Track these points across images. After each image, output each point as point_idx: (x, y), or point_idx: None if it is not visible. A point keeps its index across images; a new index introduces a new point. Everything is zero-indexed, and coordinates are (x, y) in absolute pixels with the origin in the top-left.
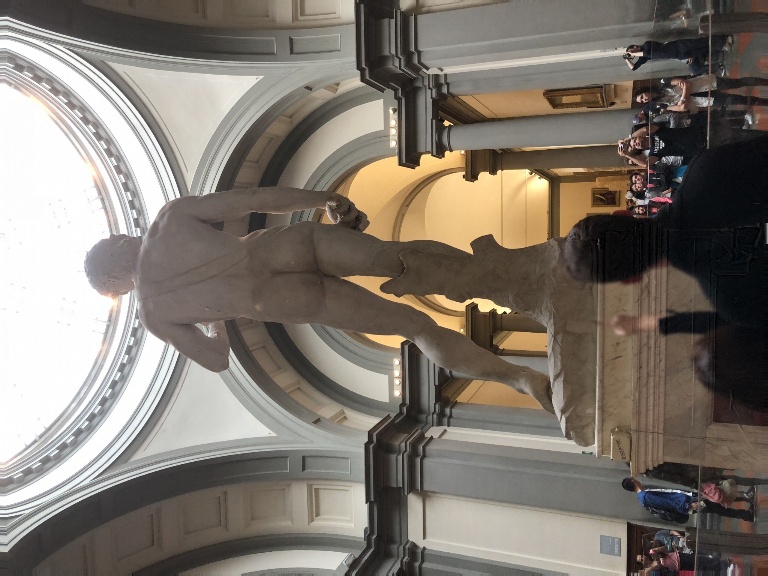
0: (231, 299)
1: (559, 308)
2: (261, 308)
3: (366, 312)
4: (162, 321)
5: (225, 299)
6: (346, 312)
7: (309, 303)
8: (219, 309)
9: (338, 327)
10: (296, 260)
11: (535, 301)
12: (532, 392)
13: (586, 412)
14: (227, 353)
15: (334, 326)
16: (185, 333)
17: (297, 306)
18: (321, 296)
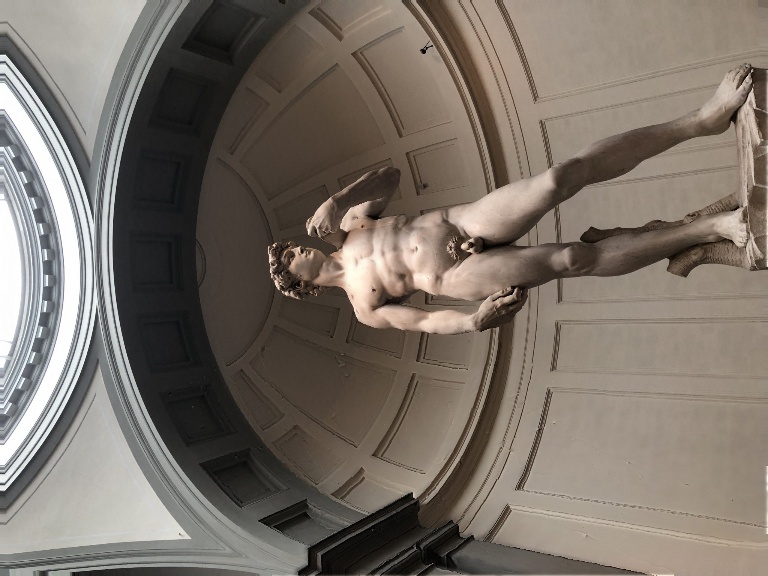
0: None
1: None
2: None
3: None
4: None
5: None
6: None
7: None
8: None
9: None
10: None
11: None
12: None
13: None
14: (396, 183)
15: None
16: None
17: None
18: None
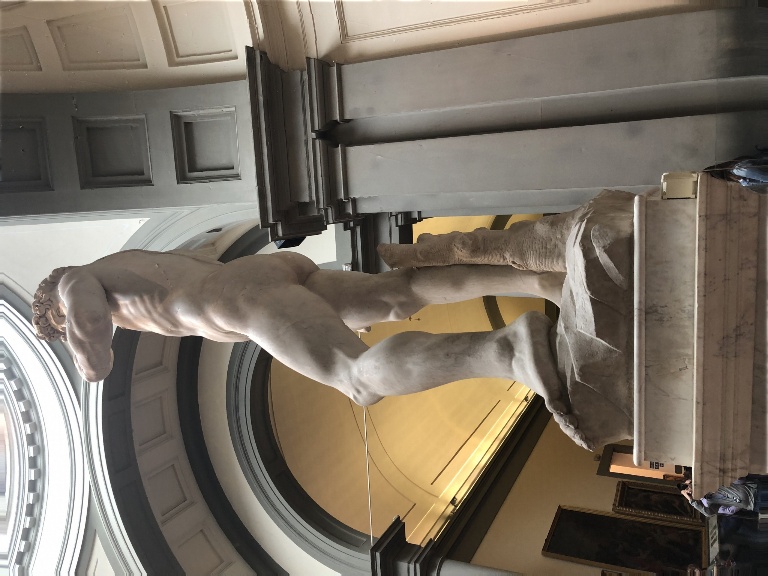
0: (190, 269)
1: (598, 200)
2: (215, 273)
3: (325, 308)
4: (91, 271)
5: (184, 267)
6: (304, 297)
7: (277, 268)
8: (167, 270)
9: (277, 313)
10: (295, 257)
11: (568, 214)
12: (525, 314)
13: (622, 215)
14: (108, 320)
15: (274, 311)
16: (98, 284)
17: (263, 263)
18: (291, 279)
